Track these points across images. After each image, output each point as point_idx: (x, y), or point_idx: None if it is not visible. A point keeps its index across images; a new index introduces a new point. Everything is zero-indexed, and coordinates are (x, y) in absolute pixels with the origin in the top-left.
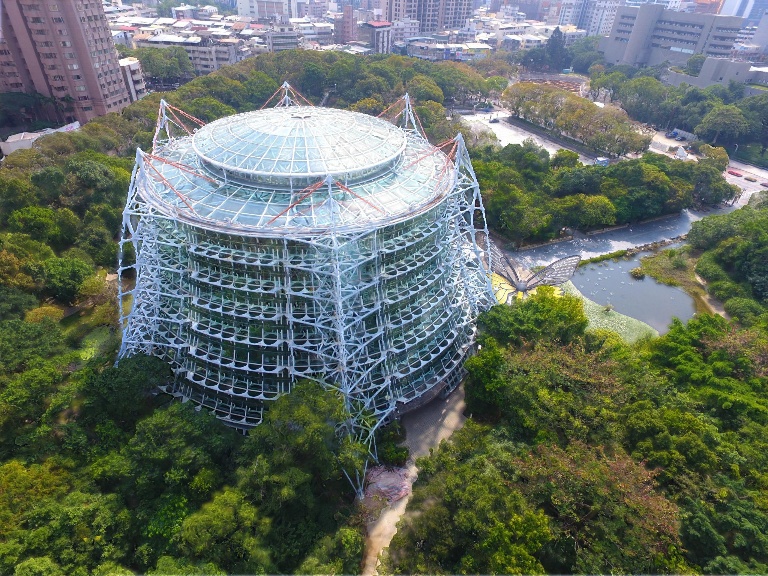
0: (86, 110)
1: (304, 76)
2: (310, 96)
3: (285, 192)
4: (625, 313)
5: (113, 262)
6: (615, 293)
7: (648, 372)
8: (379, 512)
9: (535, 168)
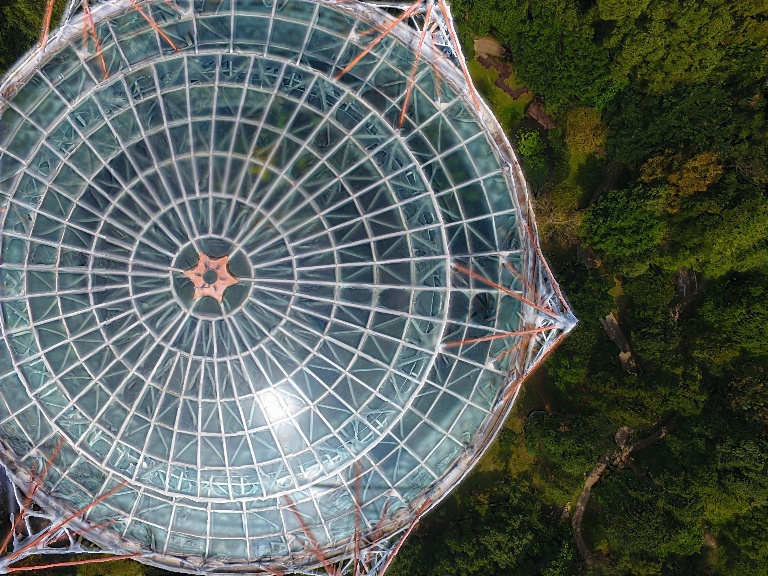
0: None
1: None
2: None
3: (212, 75)
4: None
5: (583, 268)
6: None
7: None
8: None
9: None
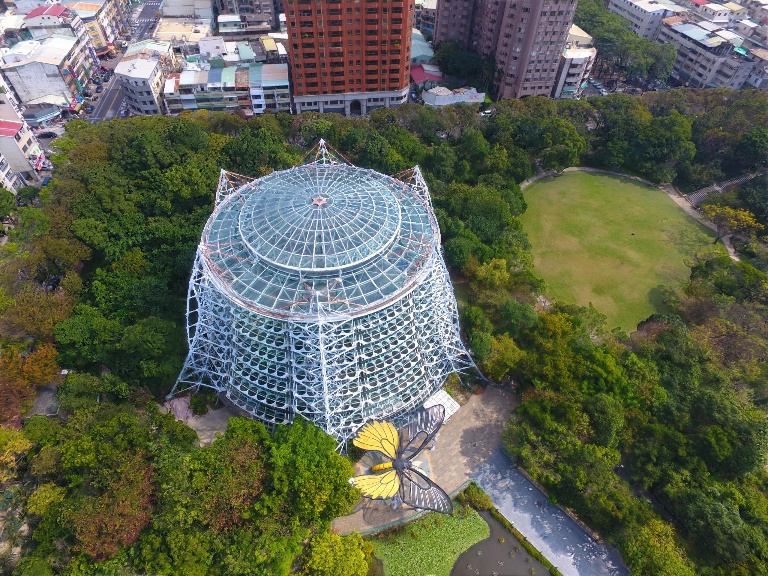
0: (507, 85)
1: (736, 142)
2: (715, 168)
3: None
4: None
5: None
6: None
7: (262, 573)
8: (140, 400)
9: (707, 451)
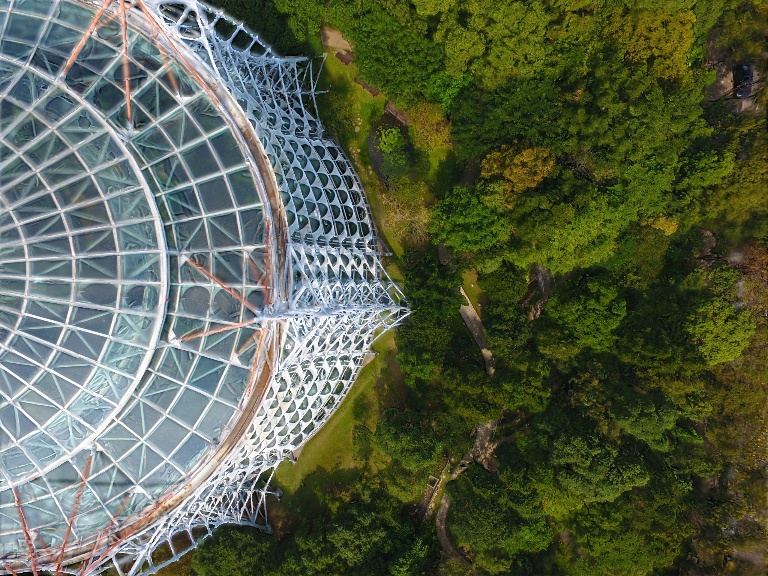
0: None
1: None
2: None
3: None
4: None
5: None
6: None
7: None
8: None
9: None
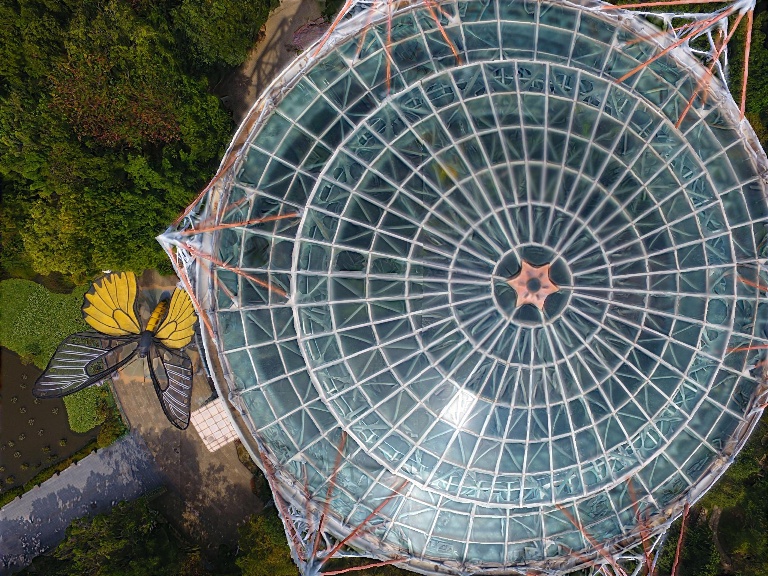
0: None
1: None
2: None
3: None
4: (8, 356)
5: None
6: (8, 403)
7: None
8: None
9: None
